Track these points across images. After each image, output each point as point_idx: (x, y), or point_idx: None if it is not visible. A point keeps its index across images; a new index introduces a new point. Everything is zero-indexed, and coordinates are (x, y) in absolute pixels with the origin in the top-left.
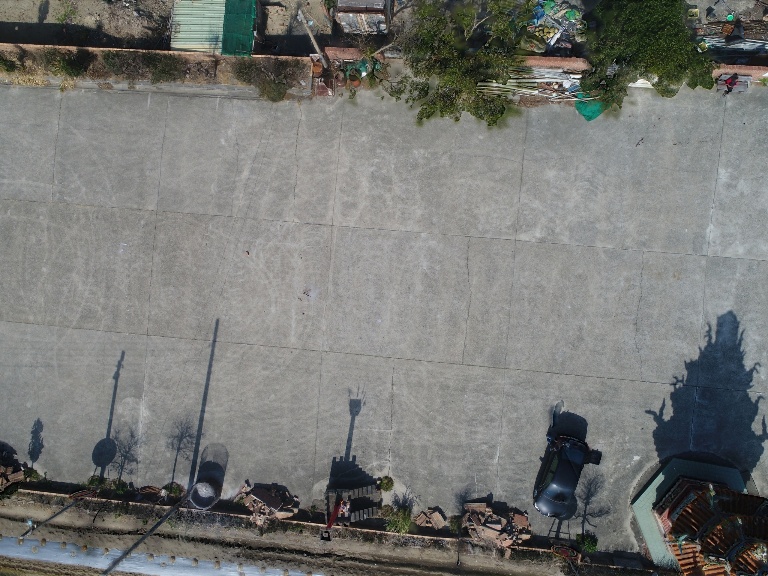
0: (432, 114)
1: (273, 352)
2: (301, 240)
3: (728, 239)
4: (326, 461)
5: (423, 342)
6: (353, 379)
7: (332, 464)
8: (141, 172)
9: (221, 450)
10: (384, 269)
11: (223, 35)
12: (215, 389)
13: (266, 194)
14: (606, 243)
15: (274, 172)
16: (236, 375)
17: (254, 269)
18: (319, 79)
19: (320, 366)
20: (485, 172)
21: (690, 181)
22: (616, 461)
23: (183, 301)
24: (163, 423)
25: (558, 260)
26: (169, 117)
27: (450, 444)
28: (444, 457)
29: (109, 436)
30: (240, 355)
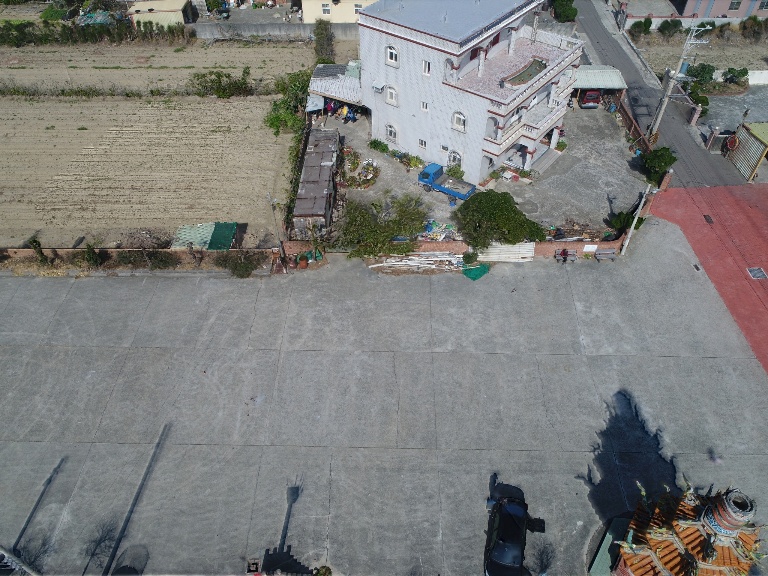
0: (358, 255)
1: (215, 450)
2: (253, 361)
3: (598, 343)
4: (258, 555)
5: (359, 432)
6: (292, 468)
7: (264, 557)
8: (125, 323)
9: (141, 552)
10: (323, 377)
11: (210, 241)
12: (149, 488)
13: (227, 332)
14: (505, 351)
15: (236, 318)
16: (174, 473)
17: (208, 384)
18: None
19: (260, 459)
20: (403, 311)
21: (557, 310)
22: (561, 528)
23: (136, 412)
24: (83, 527)
25: (469, 364)
26: (158, 290)
27: (390, 524)
28: (385, 539)
29: (16, 546)
30: (182, 454)
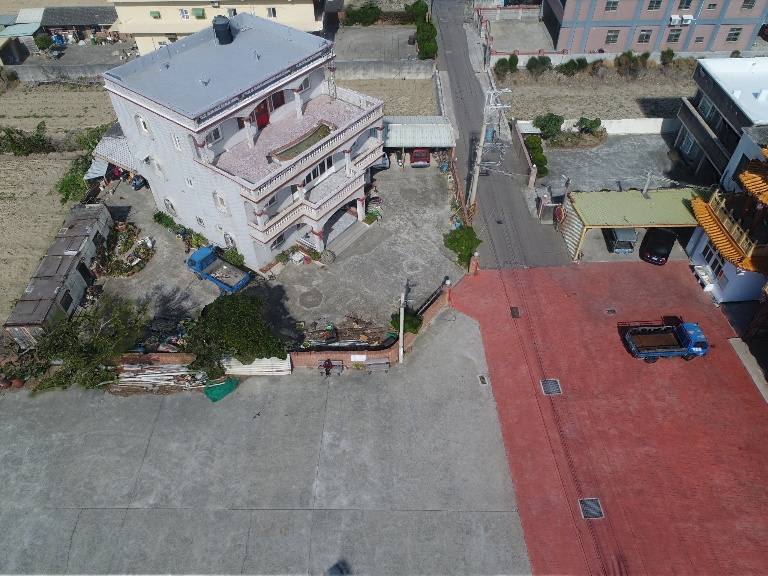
0: (47, 386)
1: None
2: None
3: (333, 492)
4: None
5: None
6: None
7: None
8: None
9: None
10: None
11: None
12: None
13: None
14: (217, 504)
15: None
16: None
17: None
18: None
19: None
20: (113, 448)
21: (298, 444)
22: None
23: None
24: None
25: (166, 525)
26: None
27: None
28: None
29: None
30: None
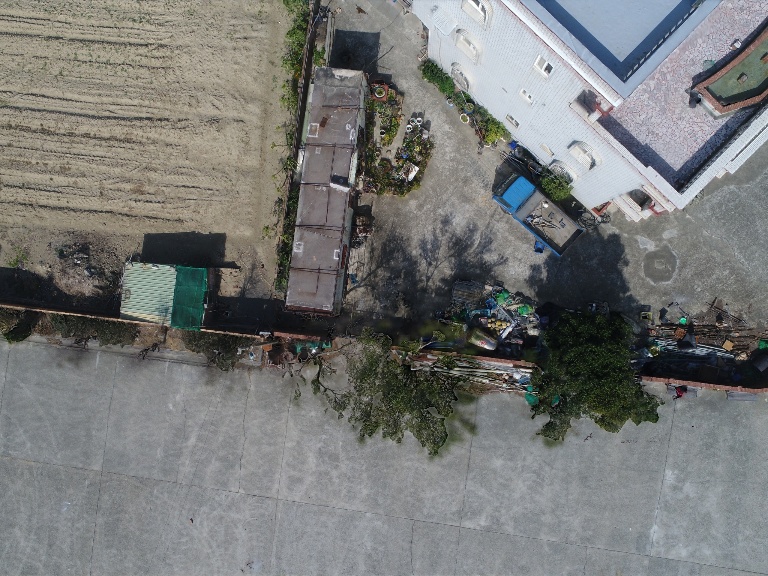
0: None
1: None
2: (246, 511)
3: (672, 541)
4: None
5: None
6: None
7: None
8: (87, 431)
9: None
10: (328, 546)
11: (173, 307)
12: None
13: (212, 463)
14: (550, 536)
15: (221, 441)
16: None
17: (197, 537)
18: (268, 361)
19: None
20: (432, 456)
21: (636, 480)
22: None
23: (125, 564)
24: None
25: (502, 550)
26: (117, 377)
27: None
28: None
29: None
30: None
